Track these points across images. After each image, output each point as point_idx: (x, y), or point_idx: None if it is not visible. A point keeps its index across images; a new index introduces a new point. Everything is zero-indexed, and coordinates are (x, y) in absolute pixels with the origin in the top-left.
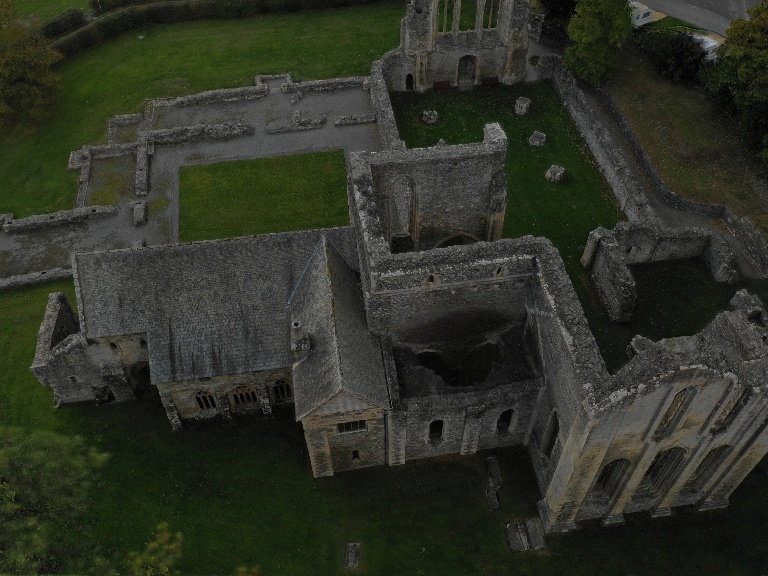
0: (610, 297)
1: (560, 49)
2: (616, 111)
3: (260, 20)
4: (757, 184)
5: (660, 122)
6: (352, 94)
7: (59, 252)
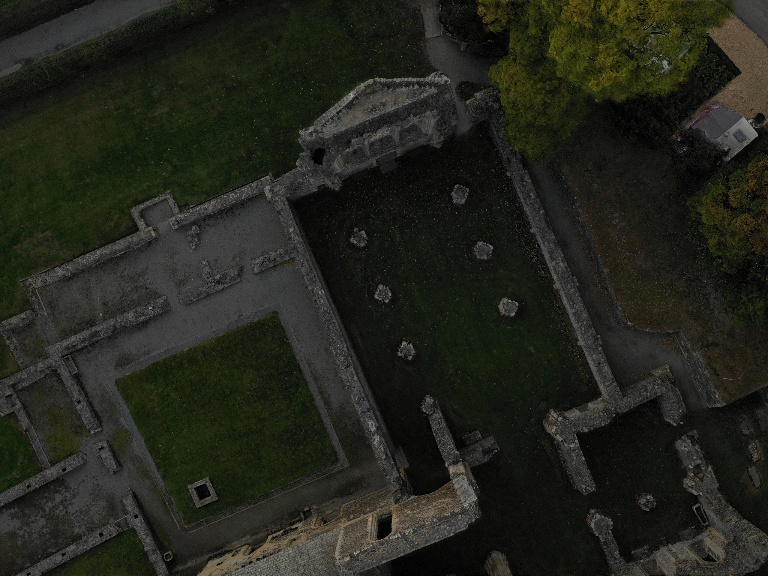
0: (572, 473)
1: (493, 57)
2: (568, 189)
3: (85, 85)
4: (714, 296)
5: (618, 214)
6: (256, 212)
7: (60, 522)
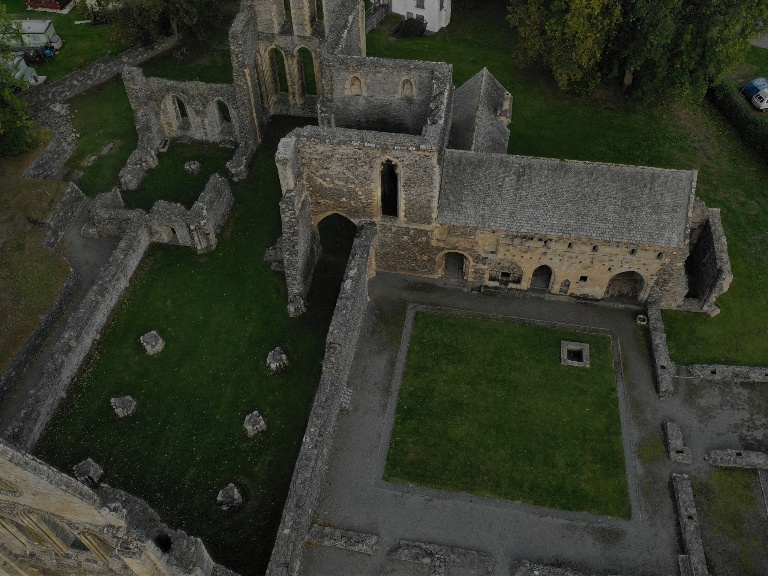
0: None
1: None
2: None
3: None
4: None
5: None
6: None
7: (764, 410)
